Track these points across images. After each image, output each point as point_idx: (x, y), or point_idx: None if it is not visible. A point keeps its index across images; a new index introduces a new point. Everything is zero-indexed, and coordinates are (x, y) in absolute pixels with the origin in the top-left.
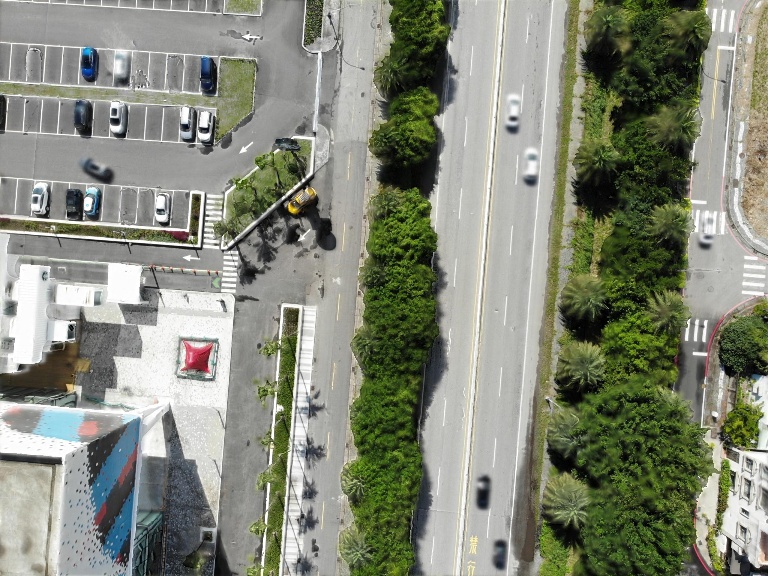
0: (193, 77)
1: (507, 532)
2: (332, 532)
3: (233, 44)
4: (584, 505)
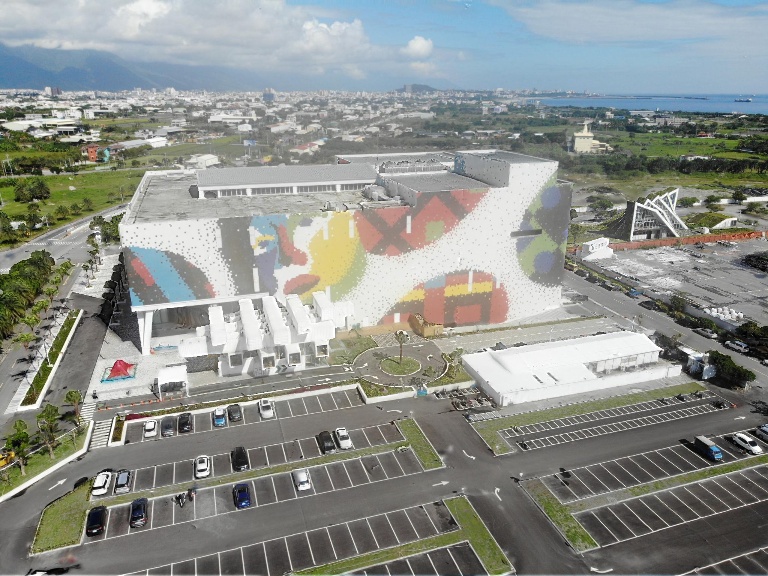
0: (119, 518)
1: None
2: None
3: (62, 561)
4: None
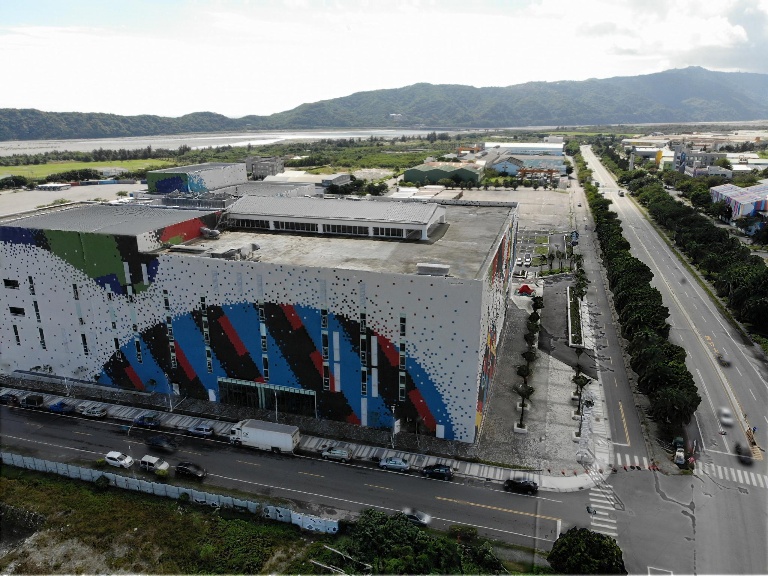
0: None
1: (729, 337)
2: (612, 330)
3: None
4: (764, 298)
